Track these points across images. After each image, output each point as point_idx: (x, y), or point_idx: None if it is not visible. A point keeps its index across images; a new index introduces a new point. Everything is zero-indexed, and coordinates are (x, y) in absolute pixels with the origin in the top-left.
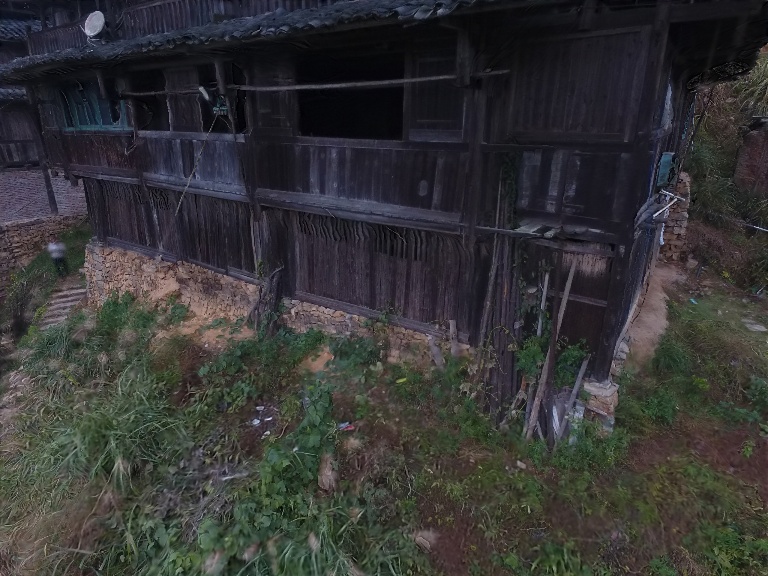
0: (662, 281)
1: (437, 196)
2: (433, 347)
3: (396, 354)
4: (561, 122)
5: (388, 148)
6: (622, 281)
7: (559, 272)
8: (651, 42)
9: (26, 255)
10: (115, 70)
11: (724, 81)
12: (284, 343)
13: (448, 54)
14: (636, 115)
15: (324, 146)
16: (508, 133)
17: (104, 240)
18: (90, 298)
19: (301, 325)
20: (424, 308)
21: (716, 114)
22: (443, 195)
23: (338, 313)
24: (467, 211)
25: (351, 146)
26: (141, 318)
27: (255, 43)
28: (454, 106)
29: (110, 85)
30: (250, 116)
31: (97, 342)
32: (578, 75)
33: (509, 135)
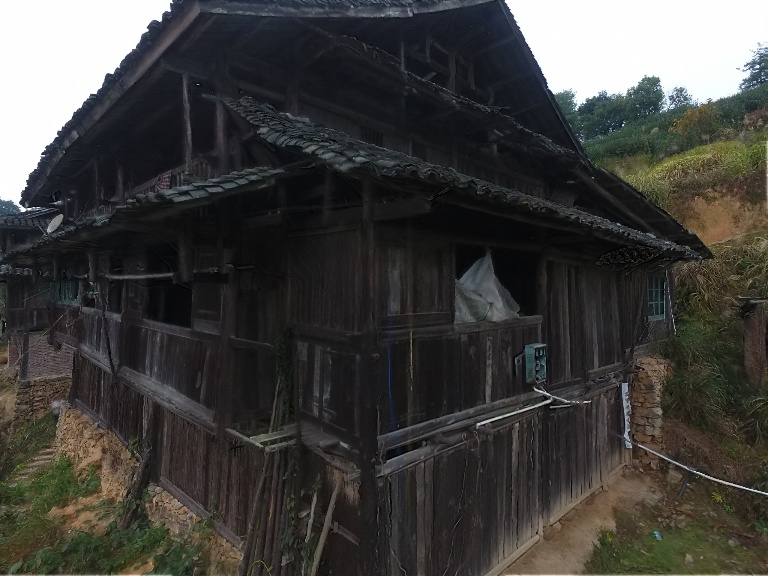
0: (620, 500)
1: (203, 390)
2: (237, 572)
3: (214, 574)
4: (318, 316)
5: (183, 336)
6: (363, 518)
7: (330, 493)
8: (362, 240)
9: (44, 409)
10: (70, 258)
11: (682, 261)
12: (128, 540)
13: (173, 253)
14: (359, 313)
15: (154, 330)
16: (286, 325)
17: (72, 402)
18: (53, 459)
19: (157, 518)
20: (238, 517)
21: (721, 292)
22: (207, 389)
23: (182, 509)
24: (218, 410)
25: (166, 331)
26: (57, 488)
27: (76, 242)
28: (216, 298)
29: (76, 269)
30: (124, 299)
31: (2, 512)
32: (326, 270)
33: (285, 327)
